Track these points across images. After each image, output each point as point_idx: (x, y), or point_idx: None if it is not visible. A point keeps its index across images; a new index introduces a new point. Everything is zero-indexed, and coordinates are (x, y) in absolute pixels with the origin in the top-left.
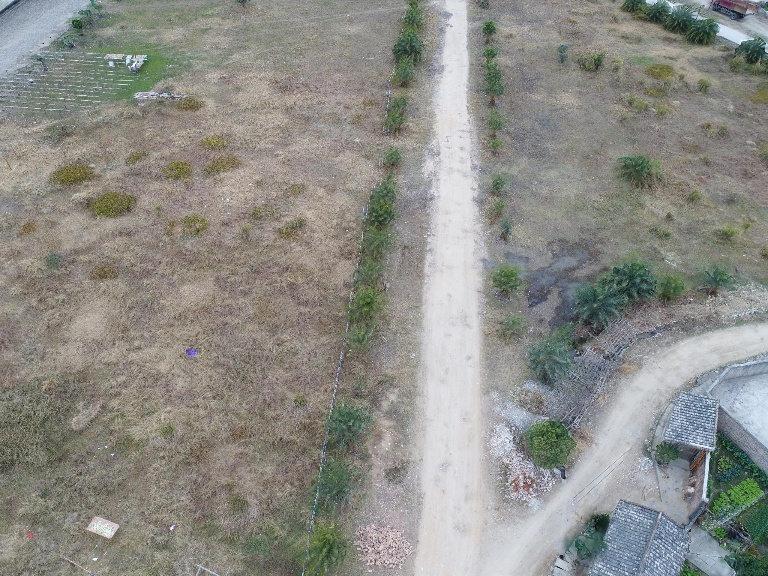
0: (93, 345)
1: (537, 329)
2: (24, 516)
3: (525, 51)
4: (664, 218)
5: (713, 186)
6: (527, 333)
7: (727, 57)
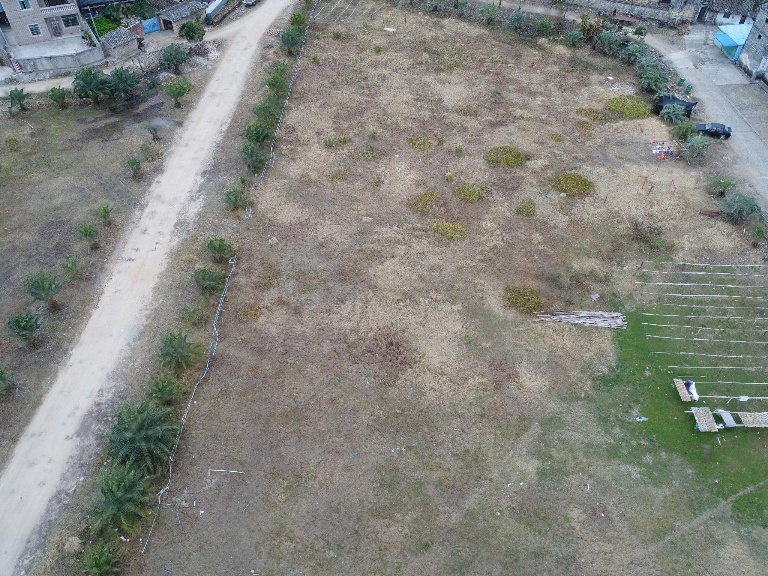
0: None
1: None
2: None
3: None
4: None
5: None
6: None
7: None
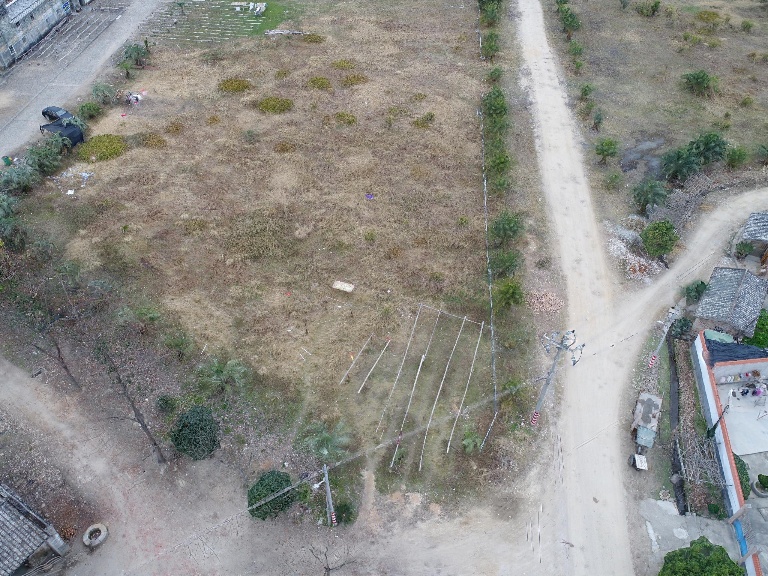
0: (293, 191)
1: (632, 185)
2: (280, 284)
3: (589, 2)
4: (723, 117)
5: (761, 96)
6: (625, 187)
7: (764, 7)
